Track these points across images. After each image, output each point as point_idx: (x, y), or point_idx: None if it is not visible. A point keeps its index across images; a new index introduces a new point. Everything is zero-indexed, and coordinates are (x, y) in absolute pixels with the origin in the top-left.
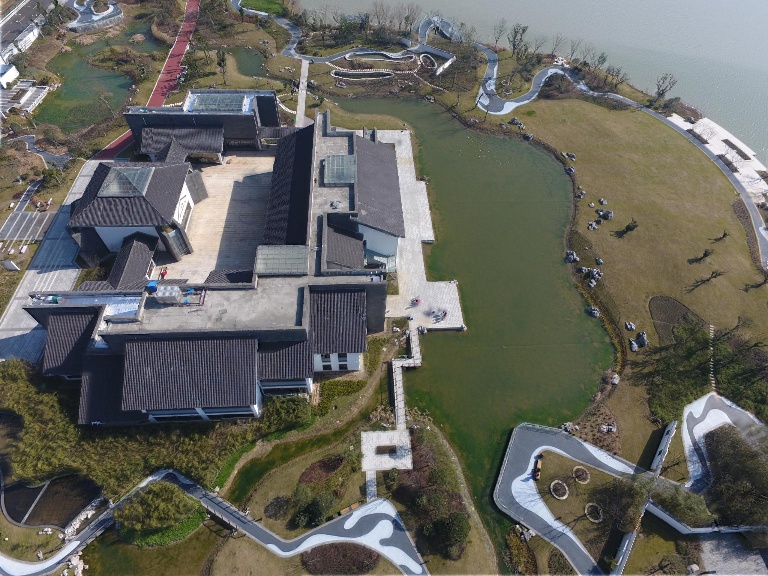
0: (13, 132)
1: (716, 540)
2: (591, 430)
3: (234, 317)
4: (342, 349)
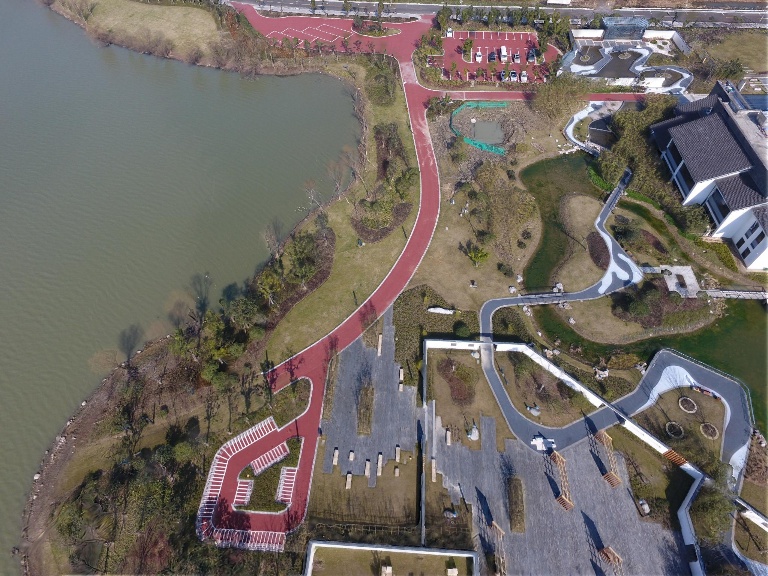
0: None
1: (679, 552)
2: (766, 461)
3: (765, 153)
4: (767, 226)
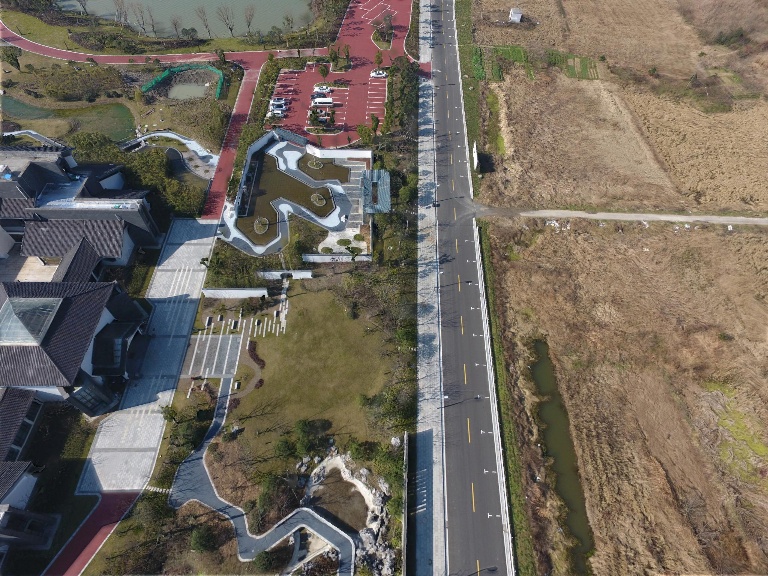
0: (283, 574)
1: None
2: None
3: None
4: None
